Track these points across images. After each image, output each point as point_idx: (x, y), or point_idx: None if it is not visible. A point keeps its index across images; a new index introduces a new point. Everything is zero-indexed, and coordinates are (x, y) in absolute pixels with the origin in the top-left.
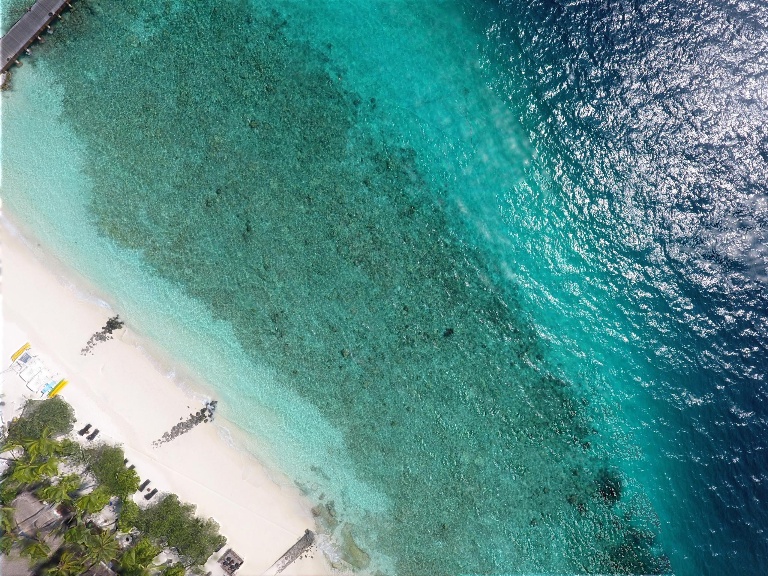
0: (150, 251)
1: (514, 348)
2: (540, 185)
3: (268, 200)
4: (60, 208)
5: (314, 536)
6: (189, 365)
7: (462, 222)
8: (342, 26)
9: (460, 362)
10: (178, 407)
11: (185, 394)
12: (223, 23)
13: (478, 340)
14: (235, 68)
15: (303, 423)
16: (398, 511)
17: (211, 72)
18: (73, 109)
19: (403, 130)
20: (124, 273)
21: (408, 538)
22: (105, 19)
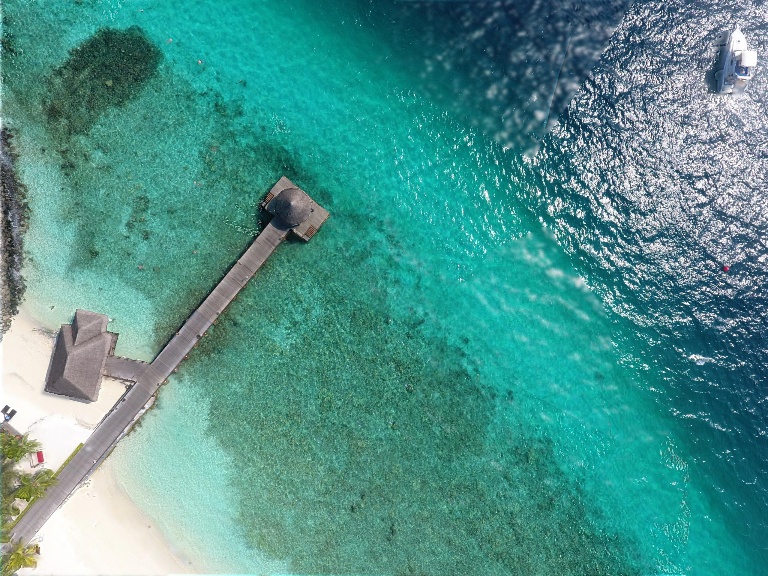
0: (298, 561)
1: None
2: (675, 466)
3: (411, 502)
4: (209, 523)
5: None
6: None
7: (601, 511)
8: (478, 320)
9: None
10: None
11: None
12: (363, 326)
13: None
14: (376, 371)
15: None
16: None
17: (352, 376)
18: (219, 422)
19: (541, 421)
20: None
21: None
22: (247, 329)
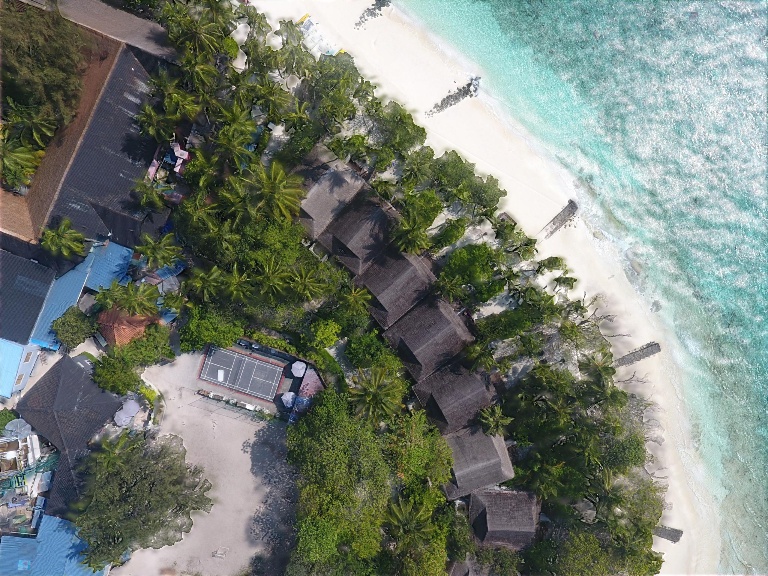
0: None
1: (755, 32)
2: None
3: None
4: None
5: (577, 206)
6: (453, 43)
7: None
8: None
9: (705, 45)
10: (445, 81)
11: (450, 70)
12: None
13: (721, 24)
14: None
15: (560, 101)
16: (652, 186)
17: None
18: None
19: None
20: None
21: (662, 212)
22: None
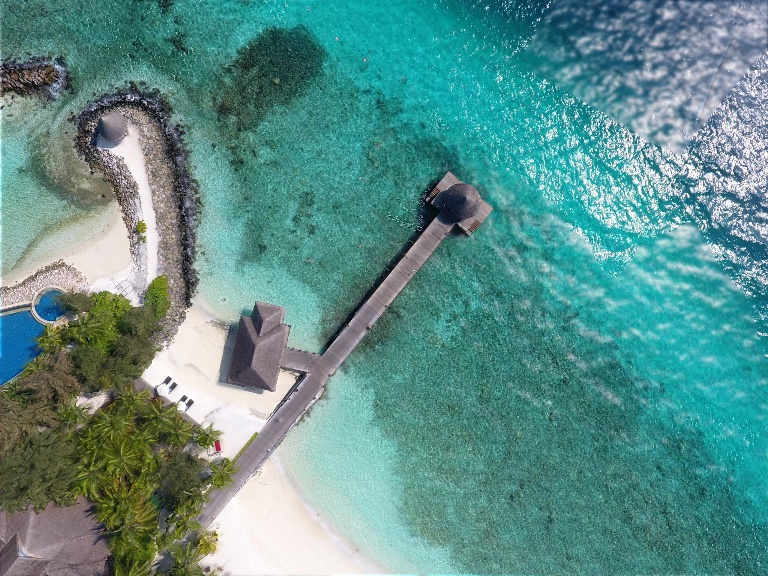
0: (460, 549)
1: None
2: None
3: (568, 491)
4: (374, 511)
5: None
6: None
7: (751, 501)
8: (630, 313)
9: None
10: None
11: None
12: (520, 319)
13: None
14: (533, 363)
15: None
16: None
17: (511, 368)
18: (383, 413)
19: (692, 413)
20: (435, 571)
21: None
22: (410, 322)
